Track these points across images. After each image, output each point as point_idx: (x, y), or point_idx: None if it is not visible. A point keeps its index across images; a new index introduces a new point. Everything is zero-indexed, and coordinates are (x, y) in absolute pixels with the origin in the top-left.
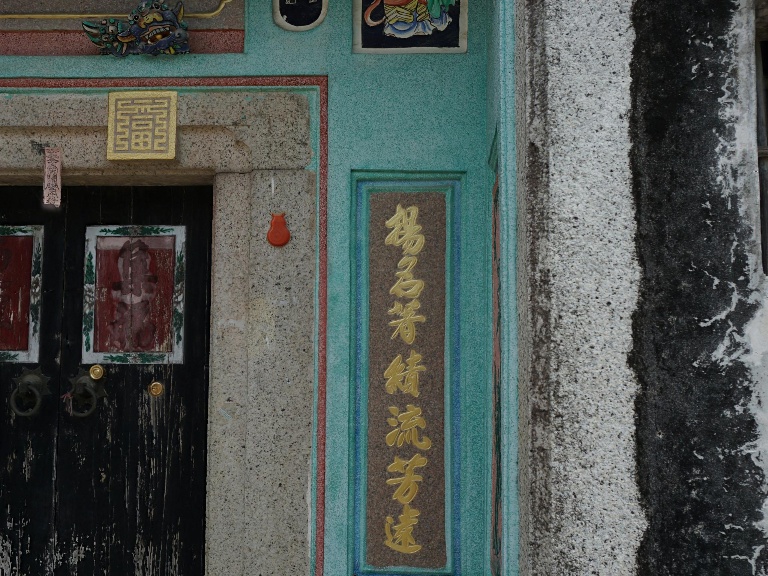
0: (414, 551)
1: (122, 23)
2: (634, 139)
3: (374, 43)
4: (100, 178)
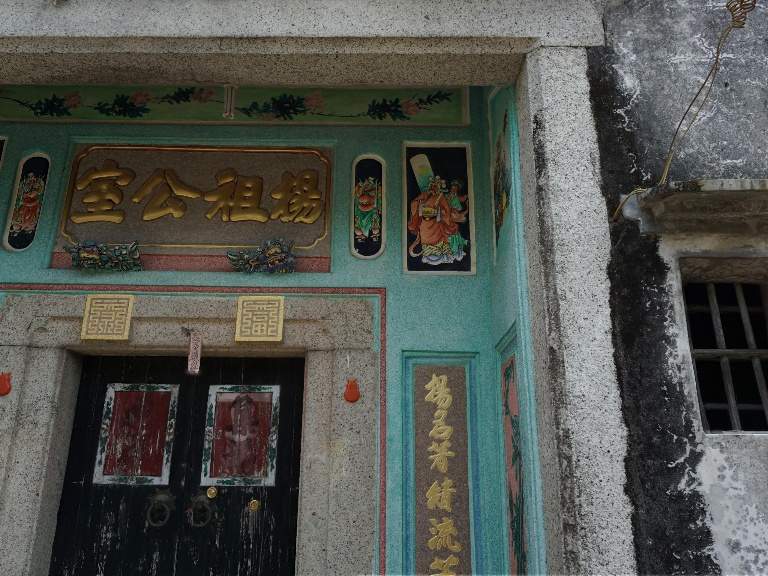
0: None
1: (253, 253)
2: (615, 346)
3: (416, 268)
4: (225, 352)
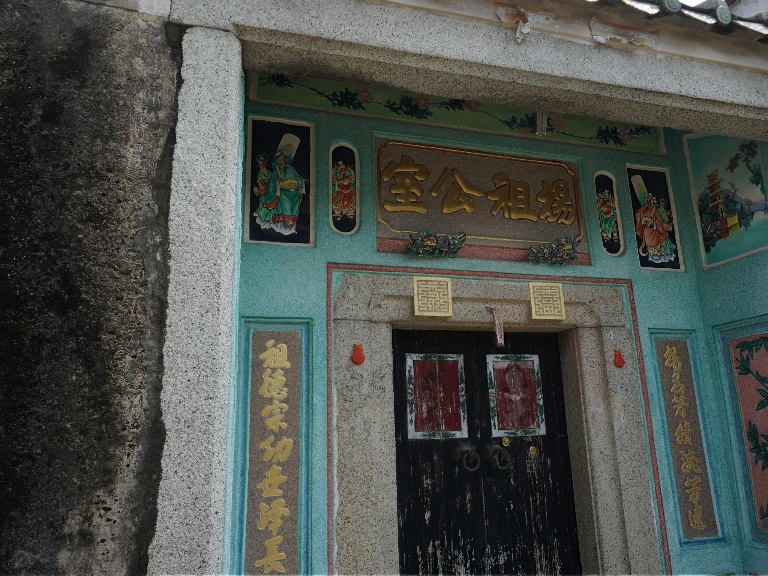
0: (703, 528)
1: None
2: None
3: (646, 264)
4: None
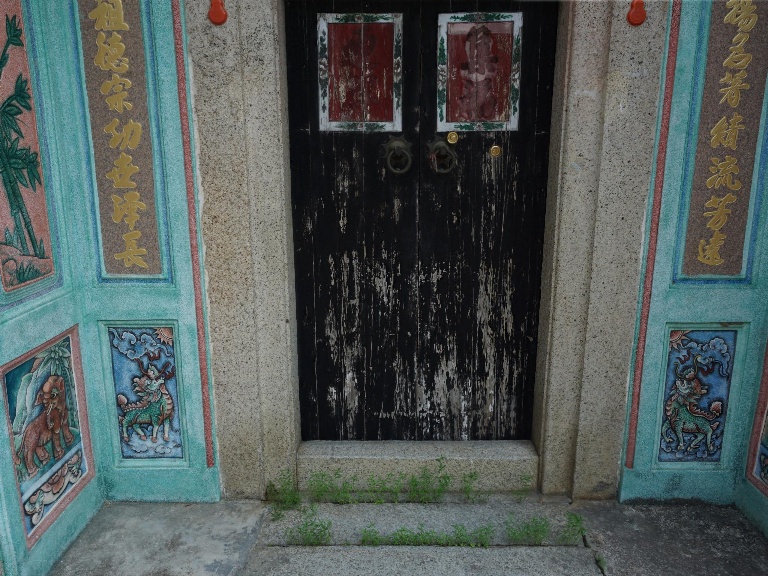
0: (718, 264)
1: None
2: None
3: None
4: None
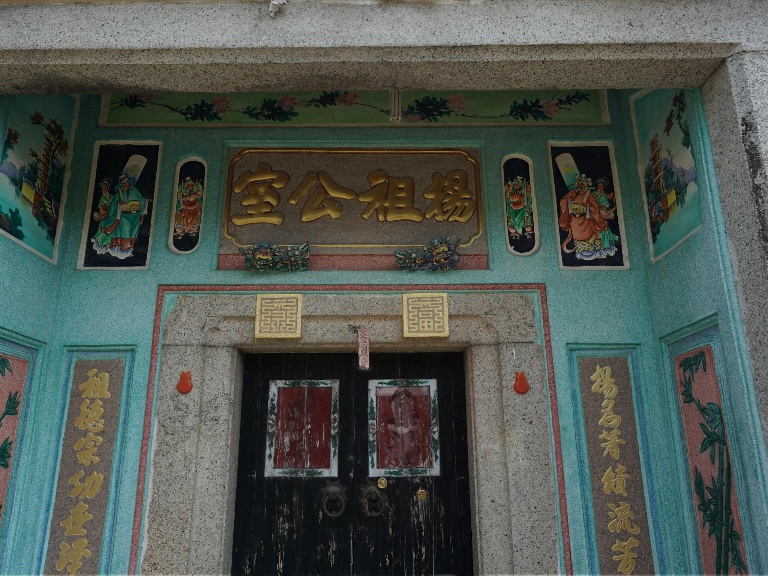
0: None
1: (419, 252)
2: None
3: (570, 263)
4: (388, 348)
